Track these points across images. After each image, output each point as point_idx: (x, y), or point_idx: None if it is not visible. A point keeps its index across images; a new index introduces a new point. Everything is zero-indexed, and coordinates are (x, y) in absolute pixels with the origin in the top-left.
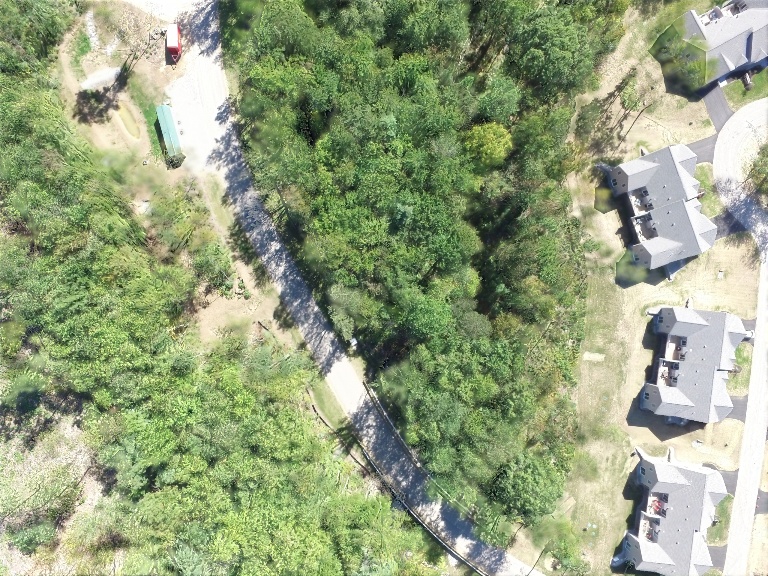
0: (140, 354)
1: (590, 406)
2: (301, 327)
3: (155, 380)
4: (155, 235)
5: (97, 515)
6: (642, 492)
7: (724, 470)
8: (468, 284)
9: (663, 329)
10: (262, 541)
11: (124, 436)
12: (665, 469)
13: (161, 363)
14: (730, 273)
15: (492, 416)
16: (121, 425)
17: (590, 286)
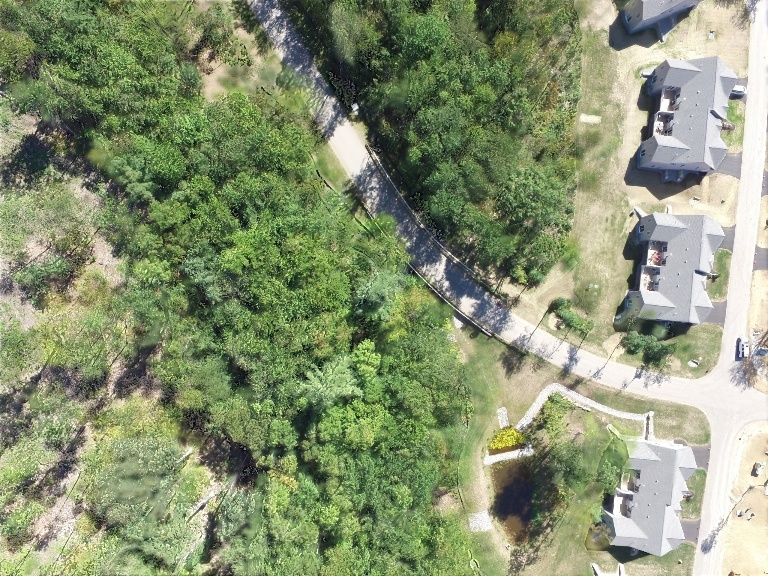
0: (147, 75)
1: (588, 167)
2: (303, 92)
3: (163, 99)
4: (158, 4)
5: (108, 275)
6: (642, 251)
7: (721, 226)
8: (465, 6)
9: (657, 86)
10: (271, 252)
11: (133, 154)
12: (663, 216)
13: (168, 83)
14: (721, 34)
15: (492, 130)
16: (130, 146)
17: (585, 49)
